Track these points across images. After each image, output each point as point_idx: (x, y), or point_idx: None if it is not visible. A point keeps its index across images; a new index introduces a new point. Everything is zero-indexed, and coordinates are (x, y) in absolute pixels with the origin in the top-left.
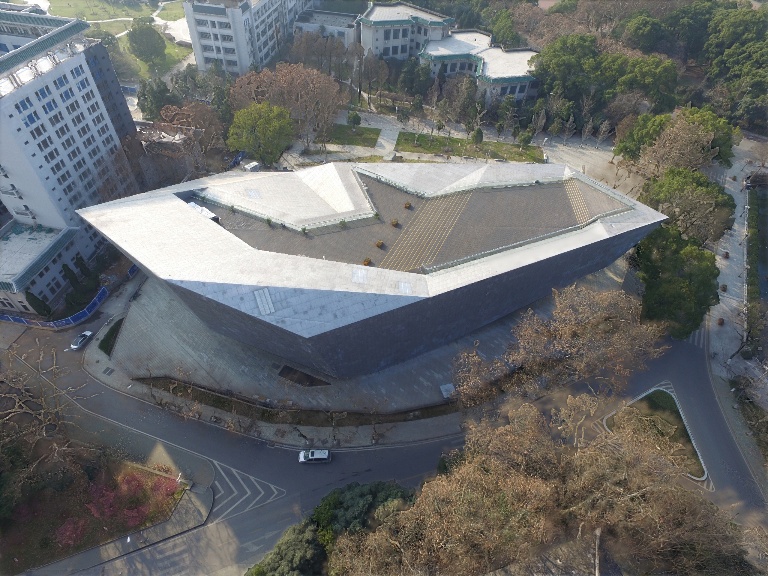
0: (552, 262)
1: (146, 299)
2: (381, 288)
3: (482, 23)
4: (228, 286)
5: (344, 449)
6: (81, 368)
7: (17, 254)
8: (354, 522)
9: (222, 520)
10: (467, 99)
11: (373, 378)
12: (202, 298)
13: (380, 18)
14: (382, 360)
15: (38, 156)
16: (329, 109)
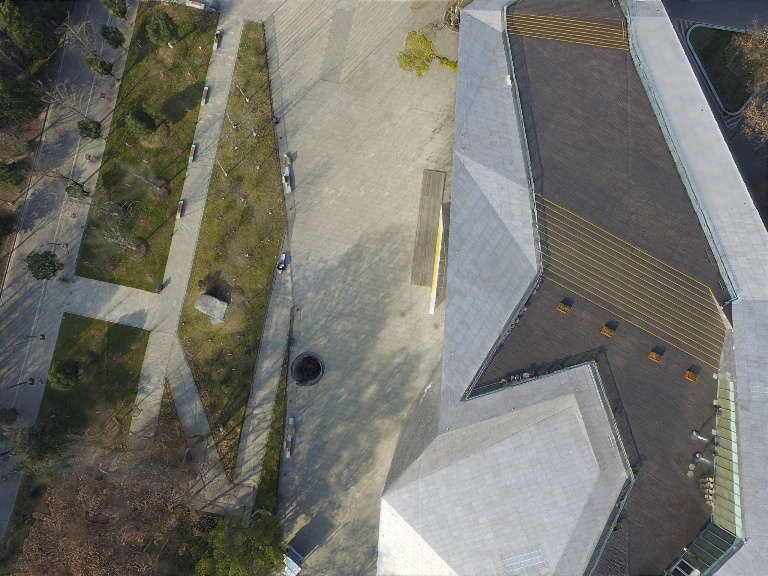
0: None
1: None
2: None
3: None
4: None
5: None
6: None
7: None
8: None
9: None
10: None
11: None
12: None
13: None
14: None
15: None
16: (3, 430)
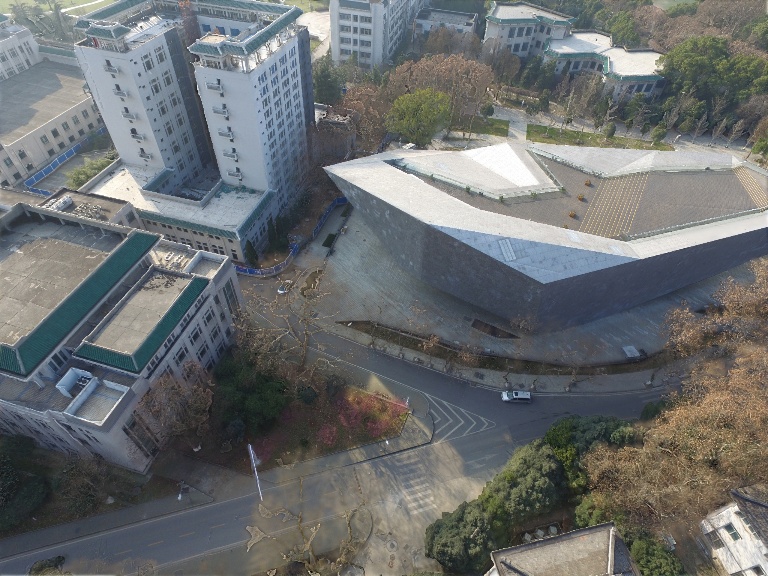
0: (741, 239)
1: (341, 255)
2: (598, 248)
3: (595, 24)
4: (478, 234)
5: (540, 394)
6: (289, 310)
7: (231, 209)
8: (595, 442)
9: (445, 441)
10: (593, 95)
11: (557, 336)
12: (454, 243)
13: (506, 16)
14: (571, 319)
15: (263, 124)
16: None
